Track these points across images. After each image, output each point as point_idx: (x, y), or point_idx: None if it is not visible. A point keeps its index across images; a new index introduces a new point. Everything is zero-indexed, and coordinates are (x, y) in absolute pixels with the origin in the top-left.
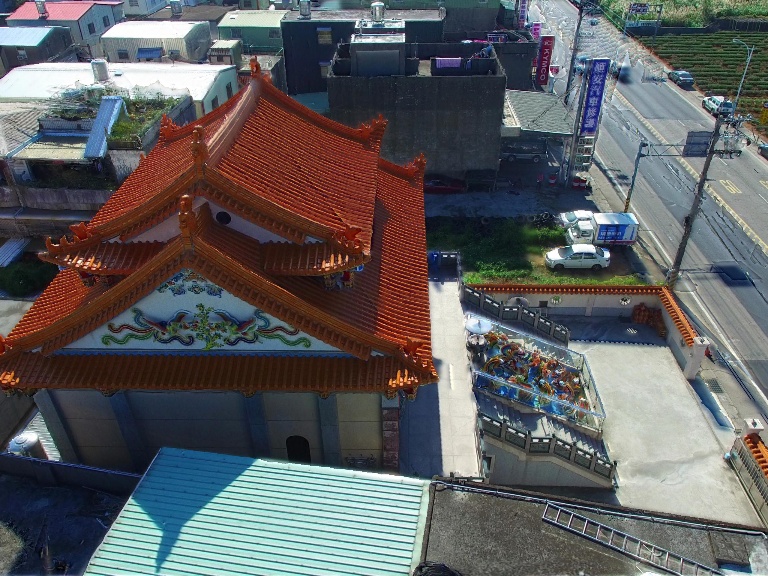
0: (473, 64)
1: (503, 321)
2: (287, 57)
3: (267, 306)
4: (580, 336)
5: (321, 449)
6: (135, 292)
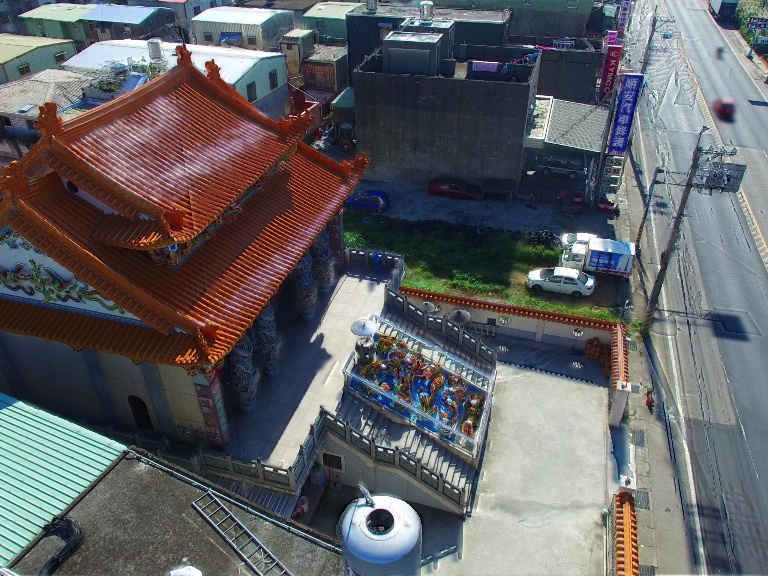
0: (510, 70)
1: (427, 330)
2: (350, 50)
3: (76, 269)
4: (518, 360)
5: None
6: None
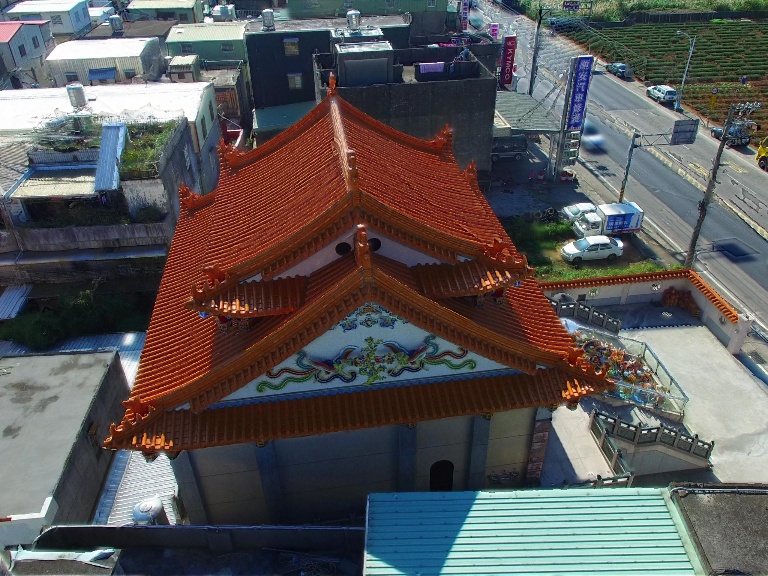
0: (456, 68)
1: None
2: (253, 70)
3: (444, 332)
4: (623, 325)
5: (465, 470)
6: (306, 333)
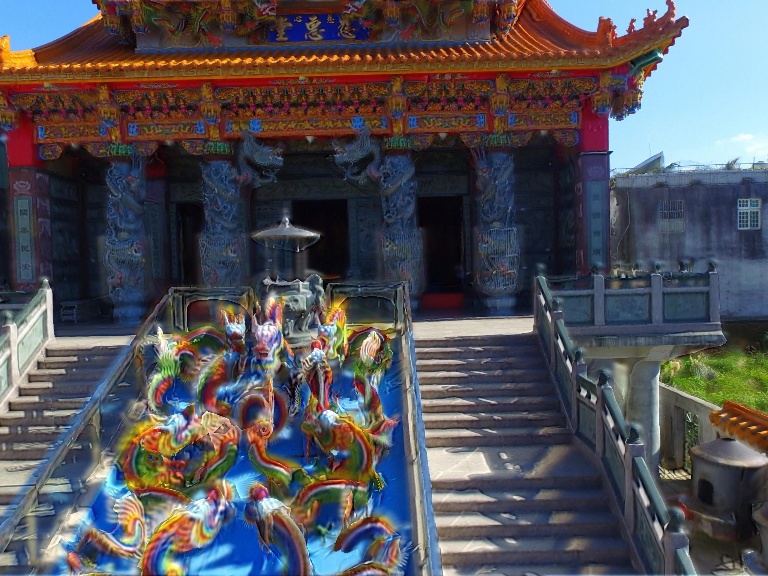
0: None
1: (575, 440)
2: None
3: None
4: None
5: None
6: None
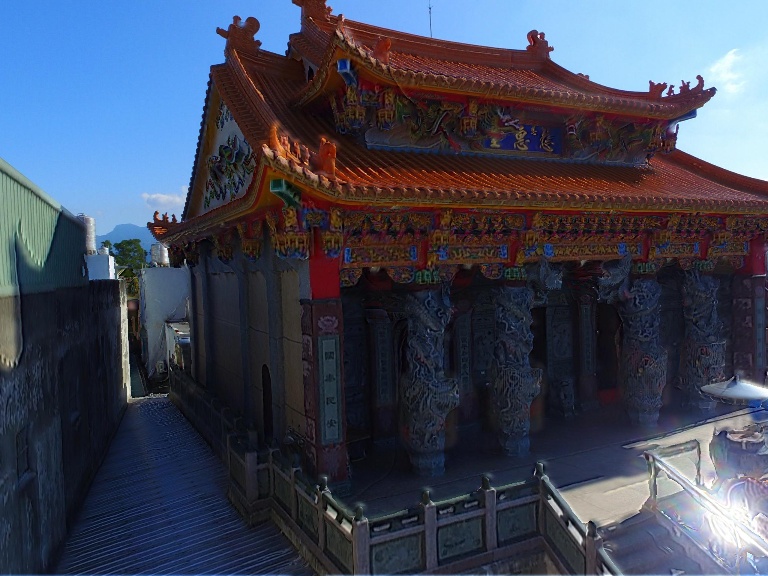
0: None
1: None
2: None
3: (237, 109)
4: None
5: None
6: None
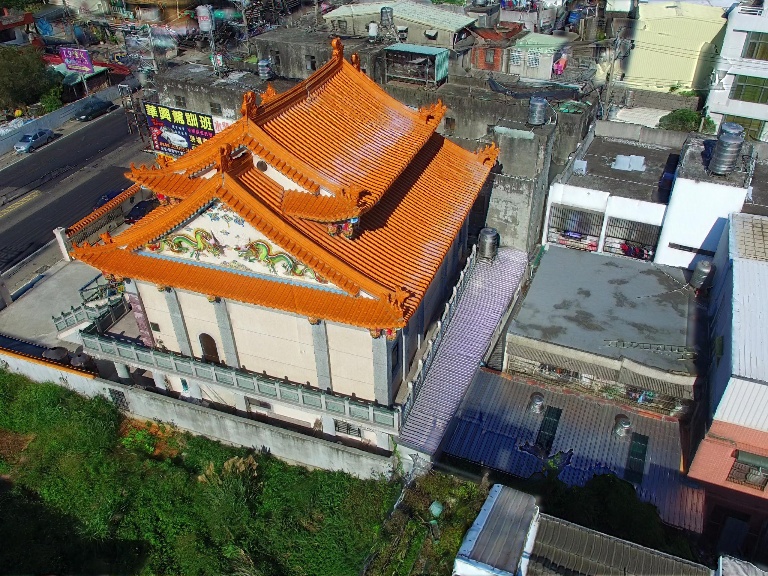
0: None
1: None
2: None
3: None
4: (30, 349)
5: None
6: None
